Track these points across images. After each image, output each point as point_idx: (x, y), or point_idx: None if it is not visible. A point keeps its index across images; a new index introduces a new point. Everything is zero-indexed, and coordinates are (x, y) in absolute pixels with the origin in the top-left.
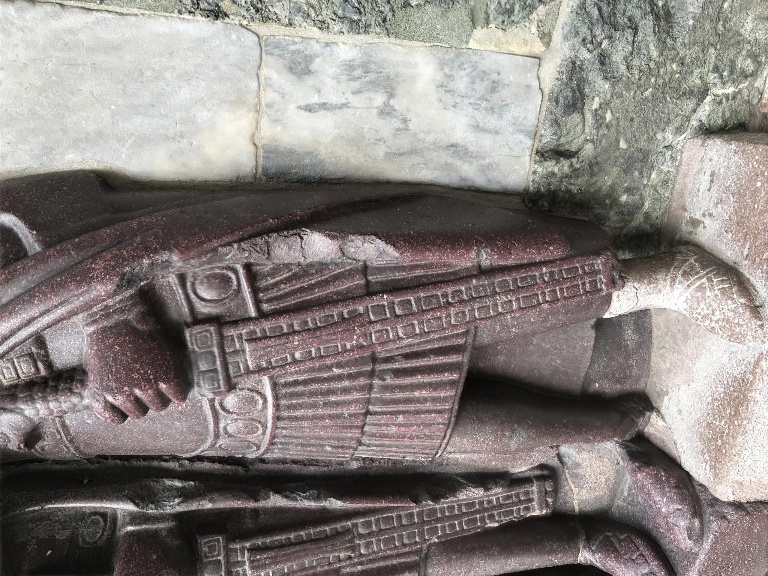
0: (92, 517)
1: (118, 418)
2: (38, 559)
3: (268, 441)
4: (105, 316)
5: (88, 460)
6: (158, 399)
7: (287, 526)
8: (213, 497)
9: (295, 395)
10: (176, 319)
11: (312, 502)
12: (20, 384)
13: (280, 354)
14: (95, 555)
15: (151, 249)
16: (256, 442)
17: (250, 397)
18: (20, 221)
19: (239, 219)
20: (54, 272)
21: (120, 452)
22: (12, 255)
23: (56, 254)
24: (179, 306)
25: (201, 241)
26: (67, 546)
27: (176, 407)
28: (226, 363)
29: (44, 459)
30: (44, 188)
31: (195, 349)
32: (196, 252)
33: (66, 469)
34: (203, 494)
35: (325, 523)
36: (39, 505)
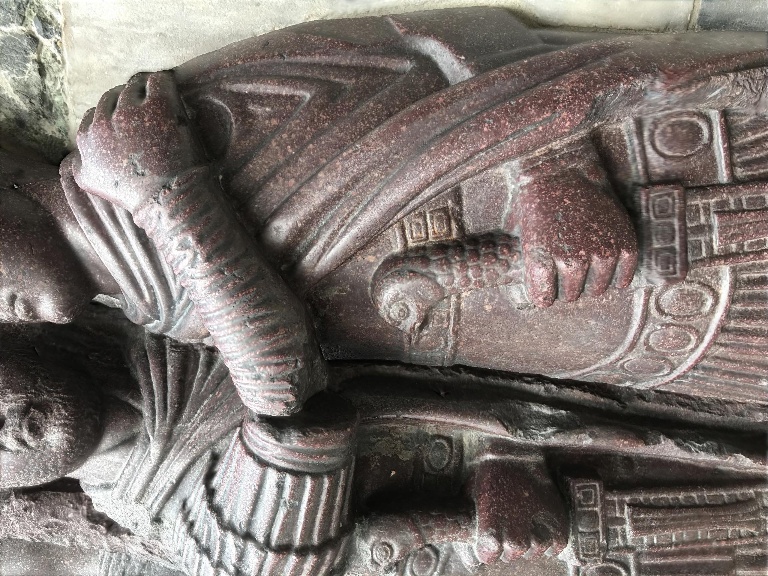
0: (436, 440)
1: (552, 296)
2: (381, 479)
3: (693, 362)
4: (550, 162)
5: (440, 370)
6: (609, 275)
7: (673, 483)
8: (594, 431)
9: (757, 298)
10: (621, 180)
11: (712, 456)
12: (427, 246)
13: (759, 235)
14: (443, 484)
15: (630, 71)
16: (675, 362)
17: (697, 294)
18: (443, 46)
19: (728, 46)
20: (501, 97)
21: (493, 360)
22: (433, 85)
23: (504, 75)
24: (628, 163)
25: (692, 65)
26: (411, 469)
27: (599, 299)
28: (686, 241)
29: (393, 363)
30: (458, 17)
31: (651, 217)
32: (685, 79)
33: (416, 378)
34: (582, 426)
35: (722, 486)
36: (394, 413)
